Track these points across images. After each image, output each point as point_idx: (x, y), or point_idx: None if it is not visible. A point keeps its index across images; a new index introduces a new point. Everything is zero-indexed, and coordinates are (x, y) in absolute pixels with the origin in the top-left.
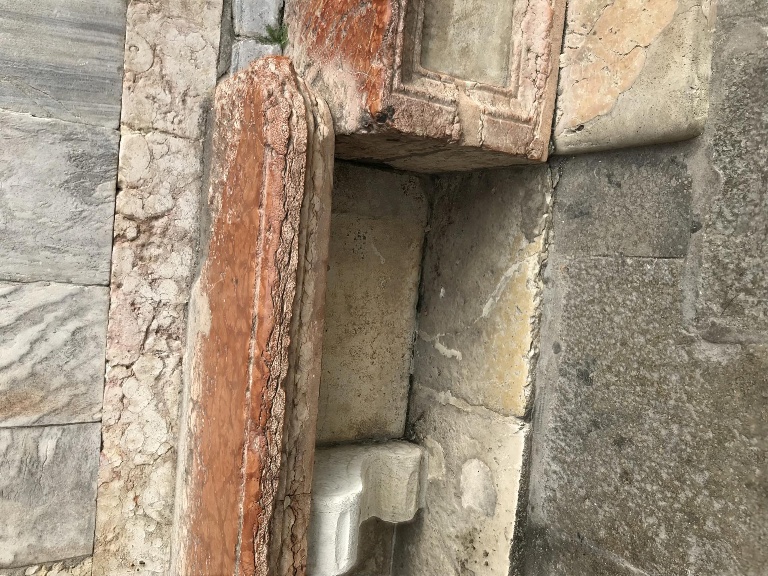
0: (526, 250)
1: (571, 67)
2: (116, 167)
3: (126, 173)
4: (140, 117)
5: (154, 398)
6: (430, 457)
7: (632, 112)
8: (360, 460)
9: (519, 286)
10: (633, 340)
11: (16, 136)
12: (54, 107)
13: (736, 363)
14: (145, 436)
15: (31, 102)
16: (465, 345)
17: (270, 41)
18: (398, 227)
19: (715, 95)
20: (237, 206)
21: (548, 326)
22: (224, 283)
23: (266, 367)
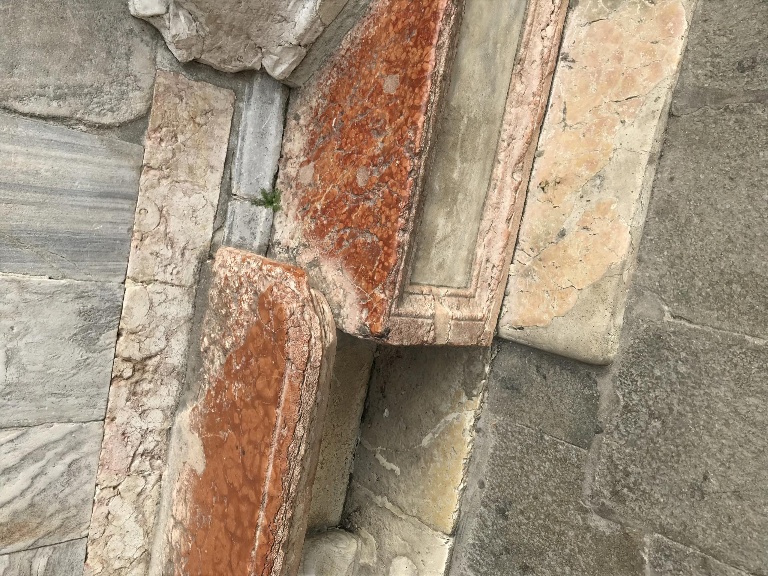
0: (465, 405)
1: (518, 277)
2: (119, 317)
3: (127, 321)
4: (144, 271)
5: (135, 511)
6: (363, 546)
7: (563, 334)
8: (312, 560)
9: (456, 432)
10: (543, 497)
11: (34, 299)
12: (69, 268)
13: (616, 537)
14: (124, 544)
15: (48, 266)
16: (404, 464)
17: (263, 202)
18: (353, 355)
19: (624, 340)
20: (247, 388)
21: (476, 466)
22: (225, 443)
23: (272, 535)
